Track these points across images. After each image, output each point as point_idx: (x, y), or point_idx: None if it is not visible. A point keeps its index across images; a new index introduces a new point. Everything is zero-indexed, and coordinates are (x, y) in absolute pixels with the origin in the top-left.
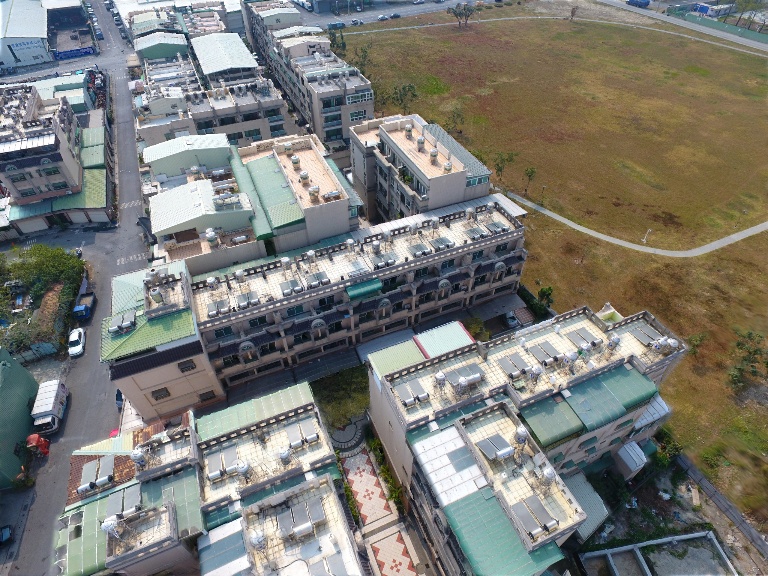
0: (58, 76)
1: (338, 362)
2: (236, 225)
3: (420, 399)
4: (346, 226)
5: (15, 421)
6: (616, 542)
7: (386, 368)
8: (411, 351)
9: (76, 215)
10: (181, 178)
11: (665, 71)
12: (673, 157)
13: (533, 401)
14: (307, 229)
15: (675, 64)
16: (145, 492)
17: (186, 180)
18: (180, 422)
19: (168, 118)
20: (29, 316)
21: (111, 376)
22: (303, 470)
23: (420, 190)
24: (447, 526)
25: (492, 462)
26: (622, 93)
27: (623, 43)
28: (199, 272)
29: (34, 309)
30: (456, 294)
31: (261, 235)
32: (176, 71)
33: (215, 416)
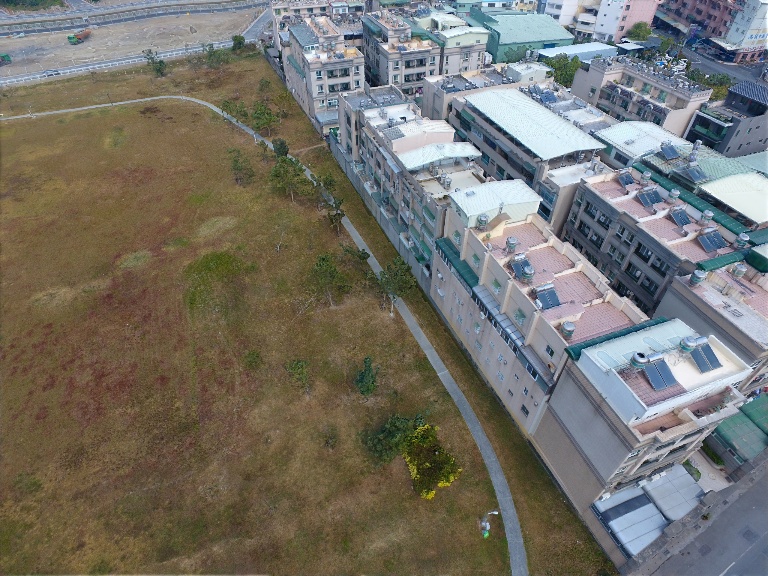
0: None
1: None
2: None
3: None
4: None
5: None
6: None
7: (358, 2)
8: (350, 4)
9: None
10: None
11: None
12: (57, 150)
13: None
14: None
15: None
16: None
17: None
18: None
19: None
20: None
21: None
22: None
23: None
24: None
25: None
26: None
27: None
28: None
29: None
30: None
31: None
32: None
33: None
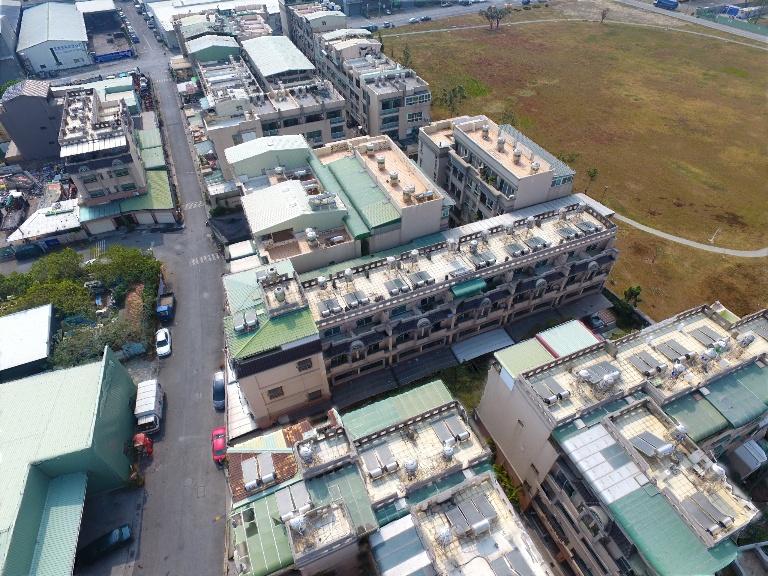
0: (101, 79)
1: (436, 361)
2: (330, 225)
3: (562, 397)
4: (437, 226)
5: (121, 420)
6: (737, 541)
7: (516, 366)
8: (537, 349)
9: (143, 216)
10: (261, 179)
11: (704, 72)
12: (726, 158)
13: (674, 399)
14: (401, 229)
15: (713, 66)
16: (311, 489)
17: (266, 181)
18: (287, 421)
19: (233, 120)
20: (111, 316)
21: (237, 375)
22: (462, 467)
23: (504, 190)
24: (608, 523)
25: (649, 459)
26: (664, 94)
27: (657, 45)
28: (299, 272)
29: (116, 309)
30: (549, 293)
31: (359, 235)
32: (230, 73)
33: (358, 414)
